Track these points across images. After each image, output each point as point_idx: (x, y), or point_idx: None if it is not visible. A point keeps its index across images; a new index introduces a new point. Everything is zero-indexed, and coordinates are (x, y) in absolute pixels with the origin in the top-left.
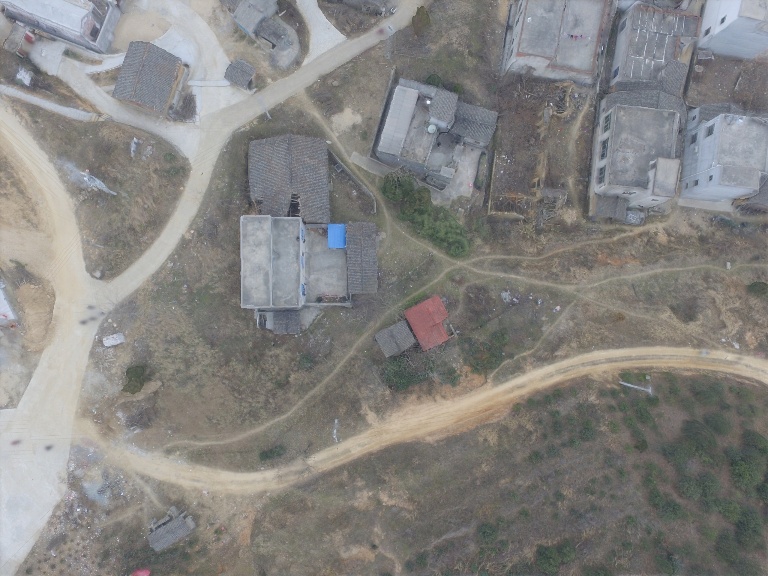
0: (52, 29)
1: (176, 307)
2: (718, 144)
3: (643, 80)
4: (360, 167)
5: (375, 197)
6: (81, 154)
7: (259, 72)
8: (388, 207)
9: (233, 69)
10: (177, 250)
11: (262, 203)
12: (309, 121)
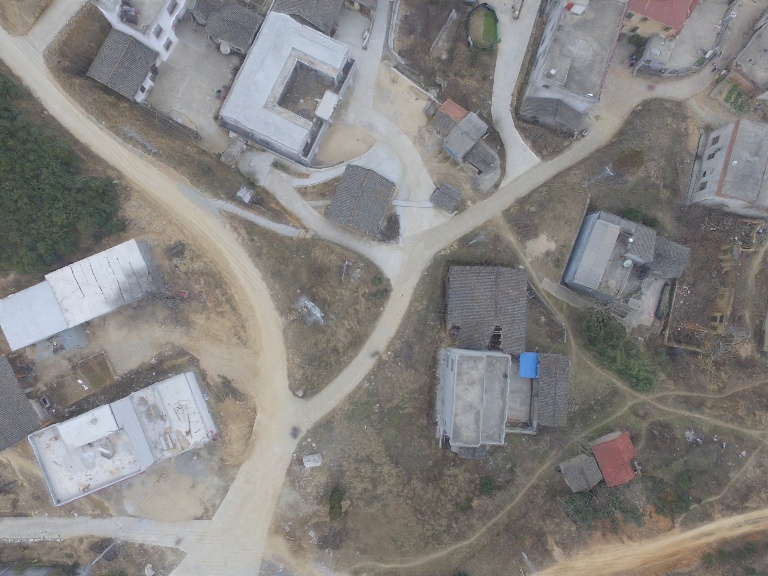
0: (265, 142)
1: (368, 426)
2: None
3: None
4: (549, 293)
5: None
6: (294, 274)
7: None
8: (575, 335)
9: (441, 194)
10: (374, 370)
11: (460, 329)
12: (504, 245)
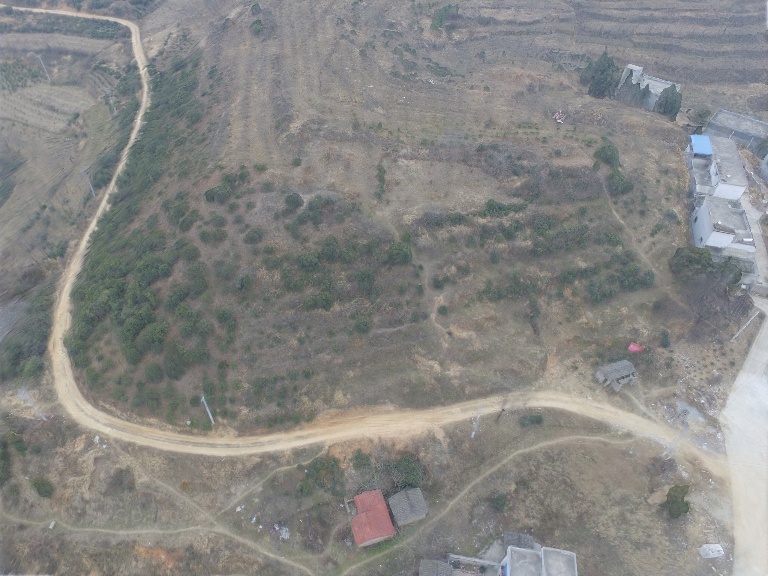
0: None
1: None
2: None
3: None
4: None
5: None
6: None
7: None
8: None
9: None
10: None
11: None
12: None
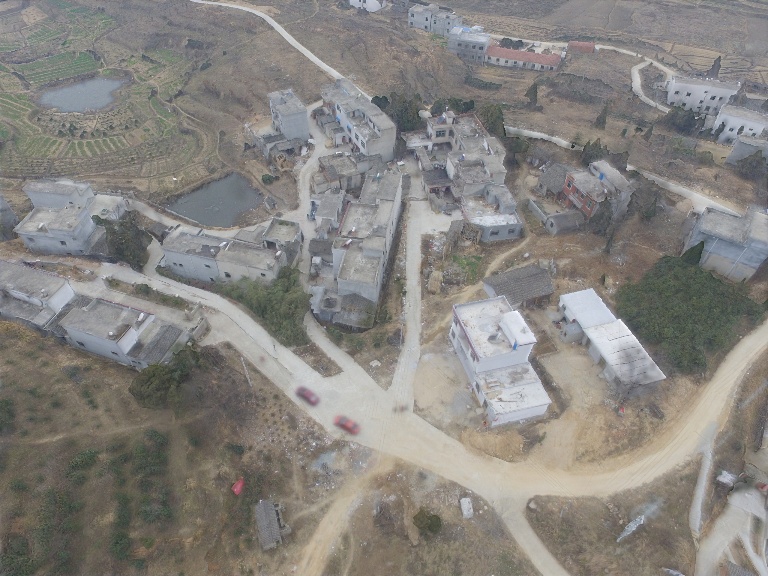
0: None
1: None
2: None
3: None
4: None
5: None
6: (656, 515)
7: None
8: None
9: None
10: None
11: None
12: None
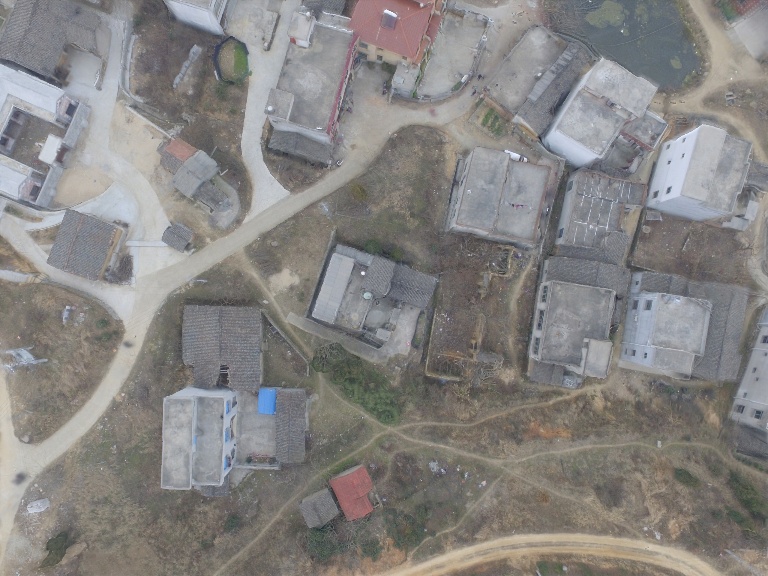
0: None
1: (105, 468)
2: (653, 324)
3: (585, 247)
4: (296, 327)
5: (309, 359)
6: (13, 321)
7: (198, 232)
8: None
9: (170, 234)
10: (107, 413)
11: (193, 368)
12: (246, 281)
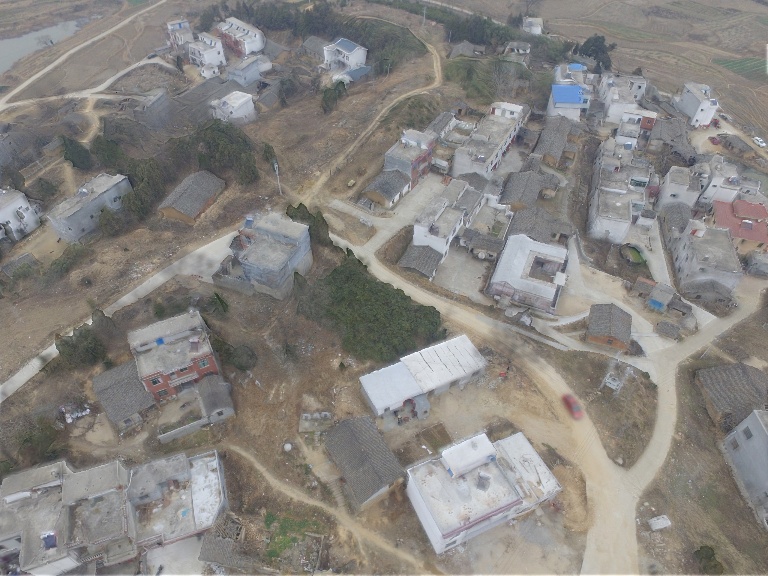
0: (522, 300)
1: (691, 500)
2: None
3: None
4: None
5: None
6: (580, 369)
7: None
8: None
9: (664, 325)
10: (673, 448)
11: (731, 414)
12: (726, 362)
